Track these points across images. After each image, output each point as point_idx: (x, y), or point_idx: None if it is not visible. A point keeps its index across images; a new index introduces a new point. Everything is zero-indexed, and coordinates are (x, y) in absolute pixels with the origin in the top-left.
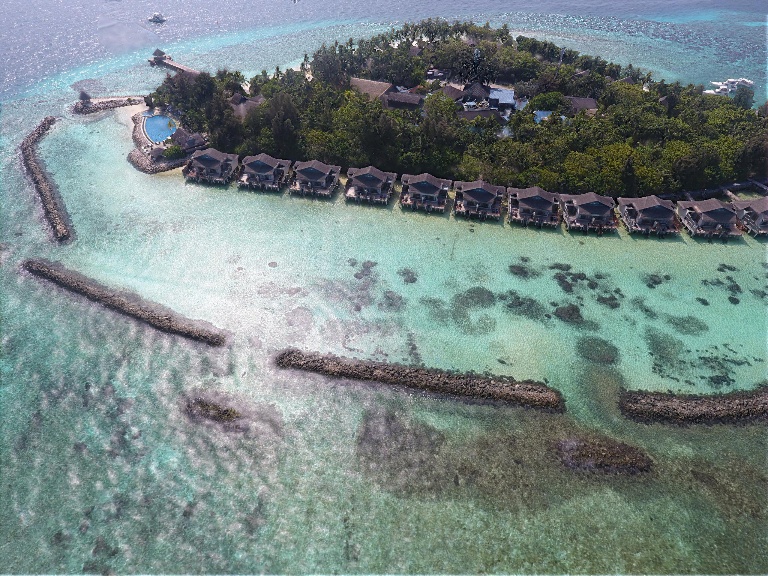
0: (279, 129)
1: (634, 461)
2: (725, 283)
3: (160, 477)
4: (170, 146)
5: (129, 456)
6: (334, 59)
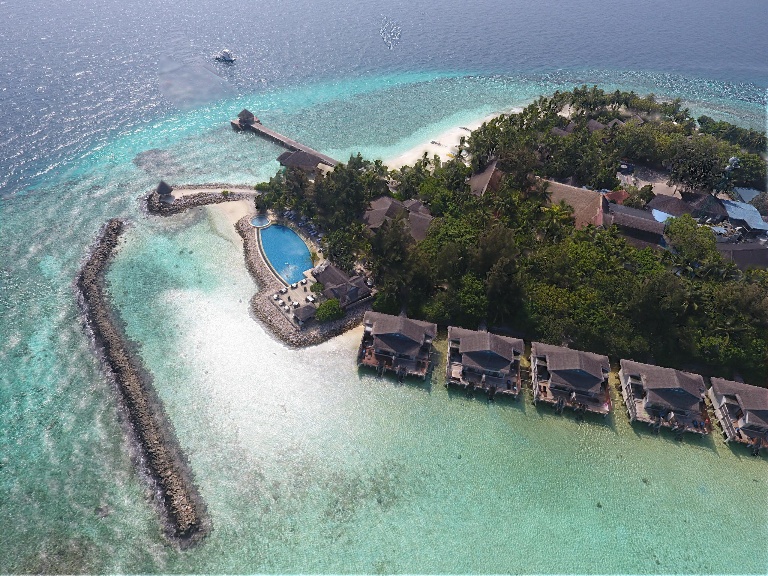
0: (500, 285)
1: None
2: None
3: None
4: (315, 293)
5: None
6: None
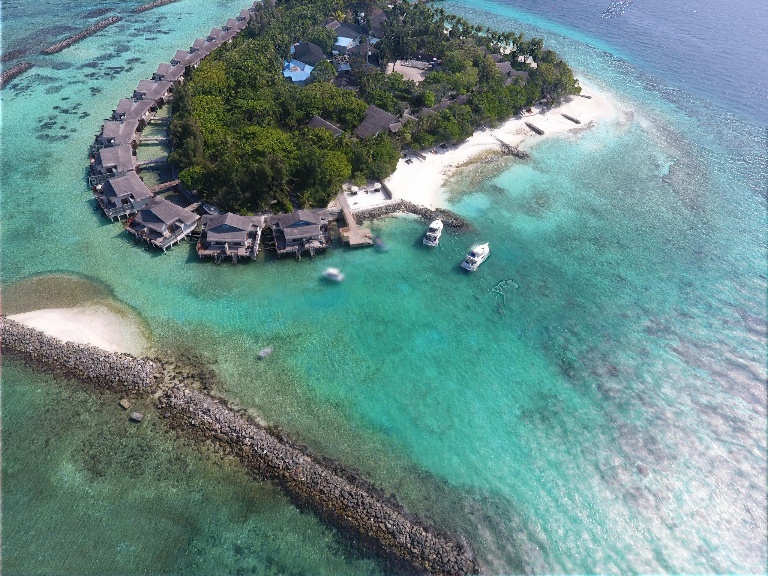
0: None
1: (3, 58)
2: (72, 110)
3: (83, 7)
4: None
5: (95, 4)
6: None
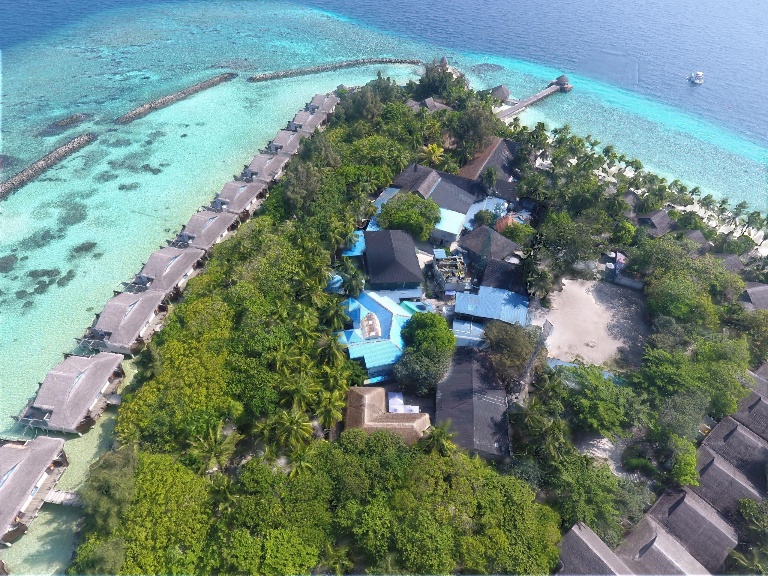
0: None
1: None
2: None
3: None
4: None
5: (67, 105)
6: (479, 118)
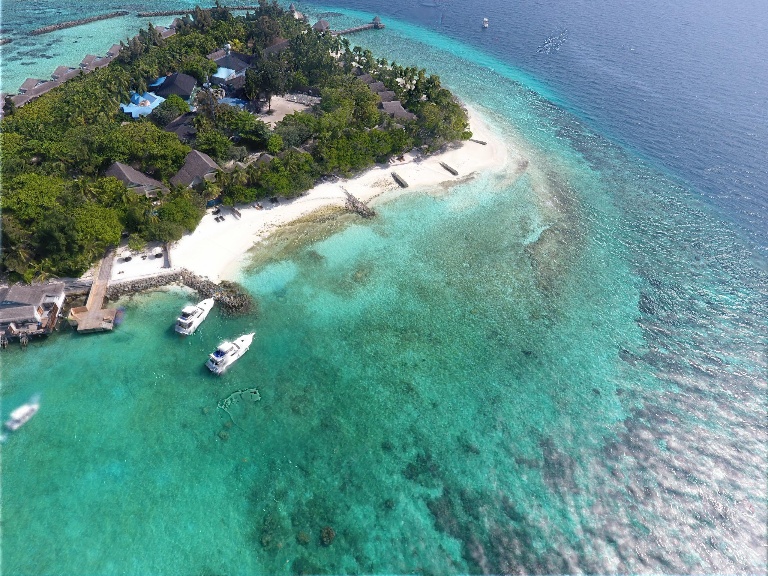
0: None
1: None
2: None
3: None
4: None
5: None
6: None
